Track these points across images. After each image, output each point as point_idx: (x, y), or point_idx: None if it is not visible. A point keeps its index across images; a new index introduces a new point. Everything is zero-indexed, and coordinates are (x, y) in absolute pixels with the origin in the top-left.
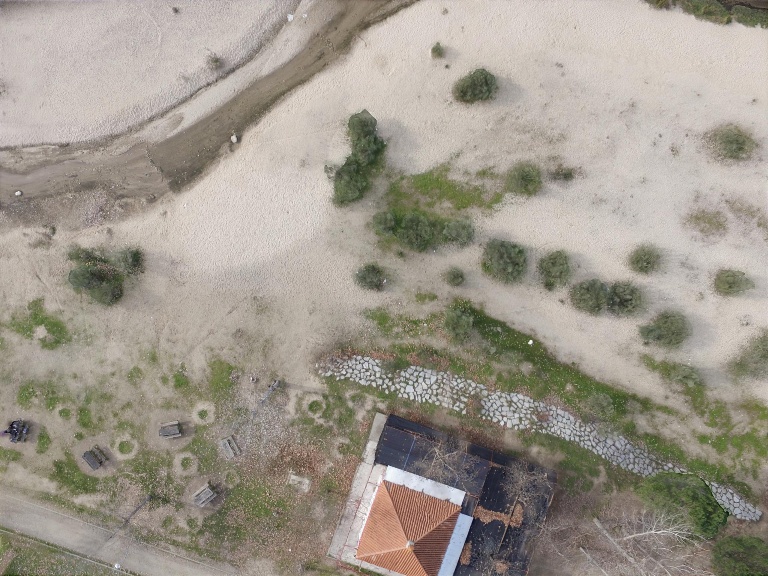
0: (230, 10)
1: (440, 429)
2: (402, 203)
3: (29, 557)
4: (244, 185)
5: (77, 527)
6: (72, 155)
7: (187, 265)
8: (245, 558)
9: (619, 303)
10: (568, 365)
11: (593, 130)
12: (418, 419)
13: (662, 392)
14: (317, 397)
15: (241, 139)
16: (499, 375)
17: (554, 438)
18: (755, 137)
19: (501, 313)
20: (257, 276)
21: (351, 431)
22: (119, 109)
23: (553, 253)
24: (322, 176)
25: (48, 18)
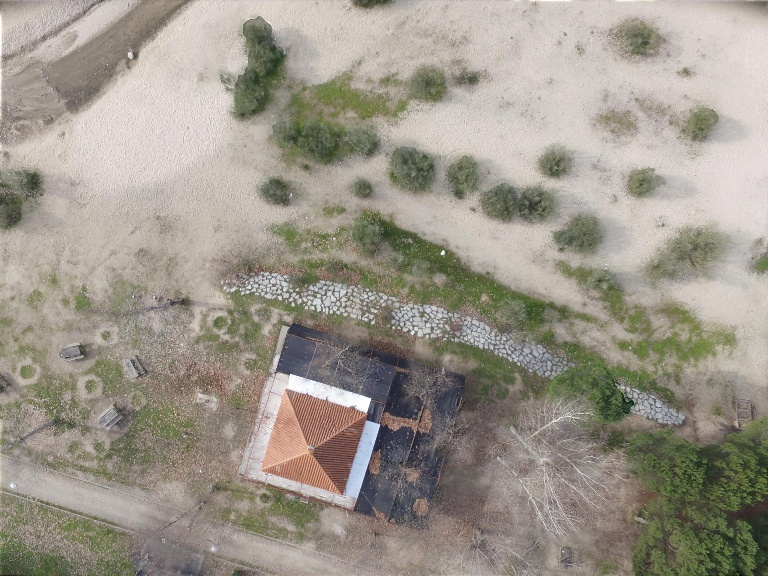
0: None
1: (348, 340)
2: (305, 114)
3: None
4: (142, 102)
5: None
6: None
7: (87, 186)
8: (155, 481)
9: (531, 208)
10: (482, 275)
11: (496, 31)
12: (325, 331)
13: (580, 299)
14: (222, 313)
15: (138, 55)
16: (412, 287)
17: (467, 346)
18: (662, 32)
19: (412, 224)
20: (160, 195)
21: (257, 346)
22: (10, 28)
23: (460, 159)
24: (222, 89)
25: None
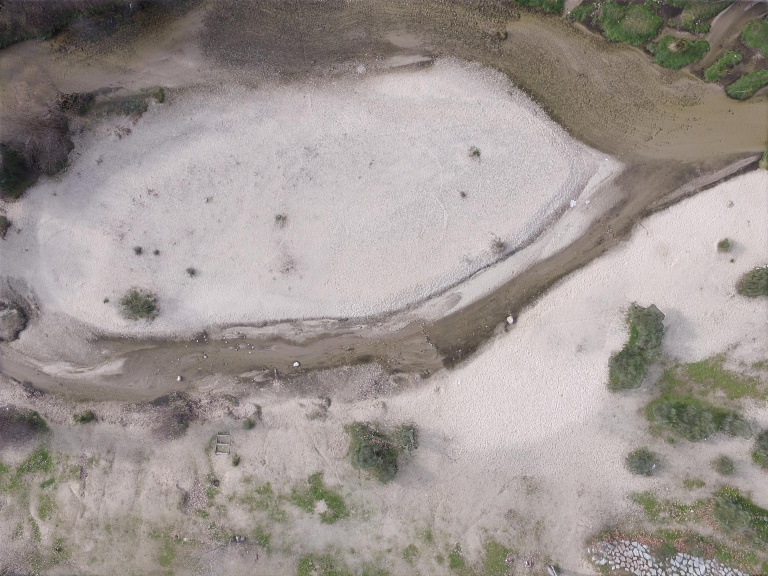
0: (517, 196)
1: None
2: (675, 390)
3: None
4: (520, 367)
5: None
6: (350, 329)
7: (459, 442)
8: None
9: None
10: None
11: None
12: None
13: None
14: None
15: (517, 320)
16: (764, 565)
17: None
18: None
19: None
20: (527, 456)
21: None
22: (402, 289)
23: None
24: (598, 362)
25: (338, 198)
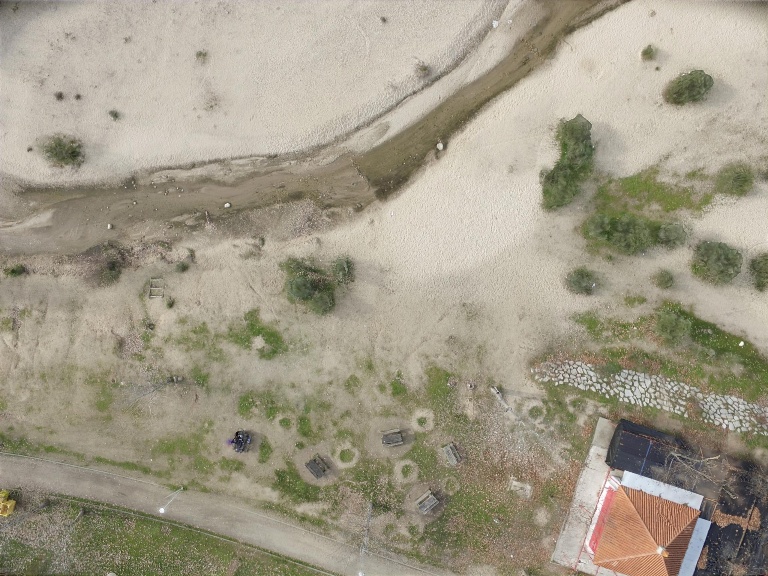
0: (438, 18)
1: None
2: (610, 206)
3: (253, 566)
4: (452, 192)
5: (299, 536)
6: (280, 166)
7: (396, 273)
8: (466, 565)
9: None
10: None
11: None
12: (641, 423)
13: None
14: (537, 403)
15: (447, 146)
16: (711, 377)
17: None
18: None
19: (711, 315)
20: (466, 283)
21: (573, 436)
22: (328, 119)
23: (767, 254)
24: (530, 181)
25: (258, 31)
